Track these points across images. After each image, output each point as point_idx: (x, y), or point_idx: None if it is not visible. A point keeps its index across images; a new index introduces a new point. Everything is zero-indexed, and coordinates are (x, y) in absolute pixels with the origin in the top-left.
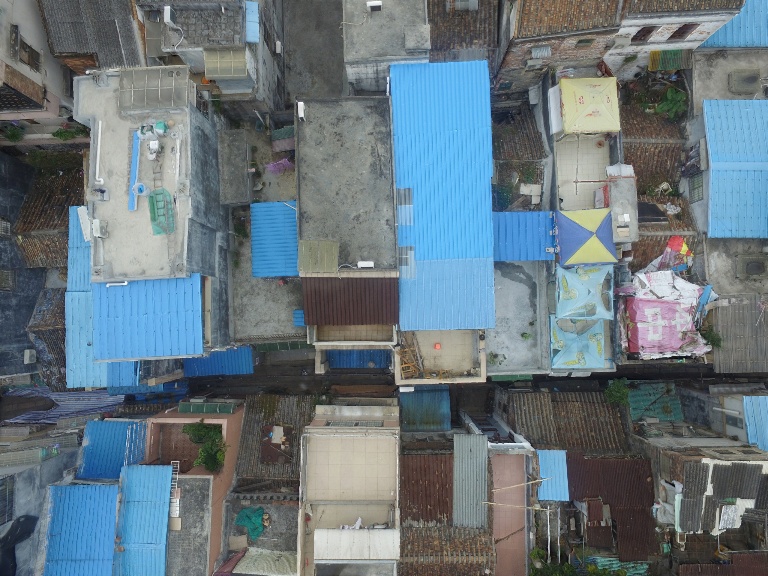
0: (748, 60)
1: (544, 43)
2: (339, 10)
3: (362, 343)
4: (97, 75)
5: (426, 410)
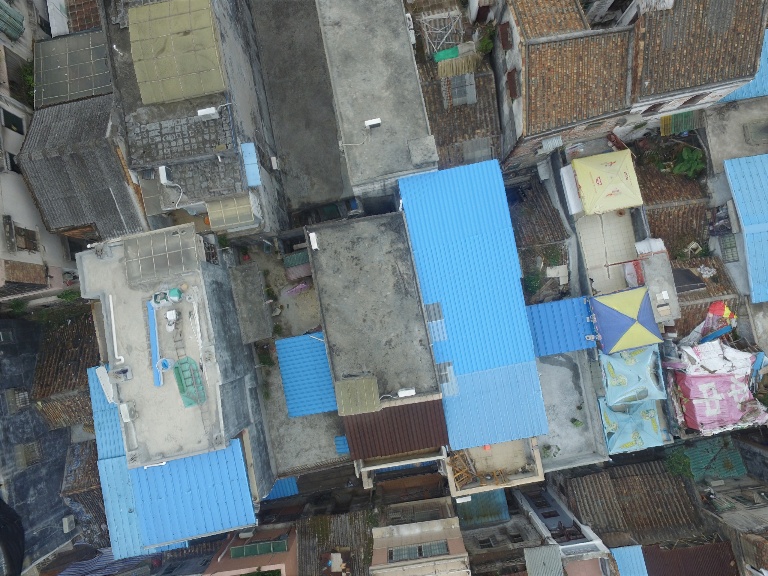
0: (760, 107)
1: (554, 134)
2: (327, 105)
3: (411, 462)
4: (100, 249)
5: (481, 502)
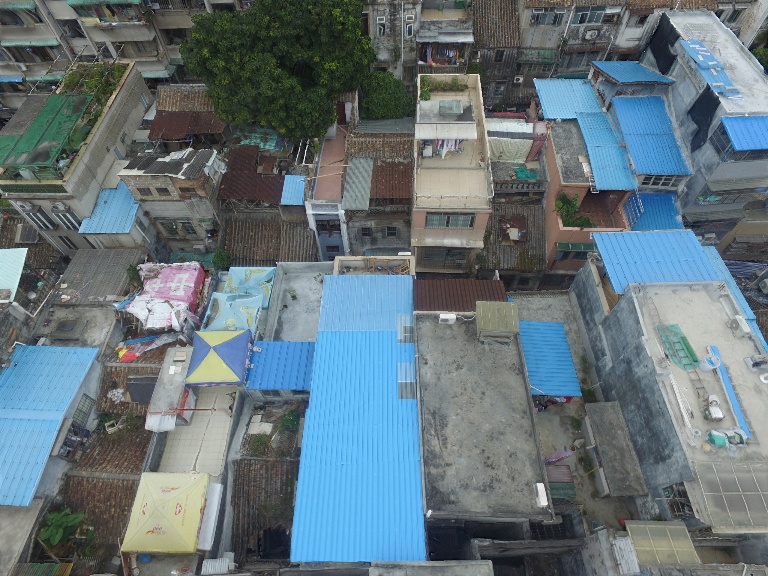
0: None
1: None
2: None
3: None
4: None
5: None
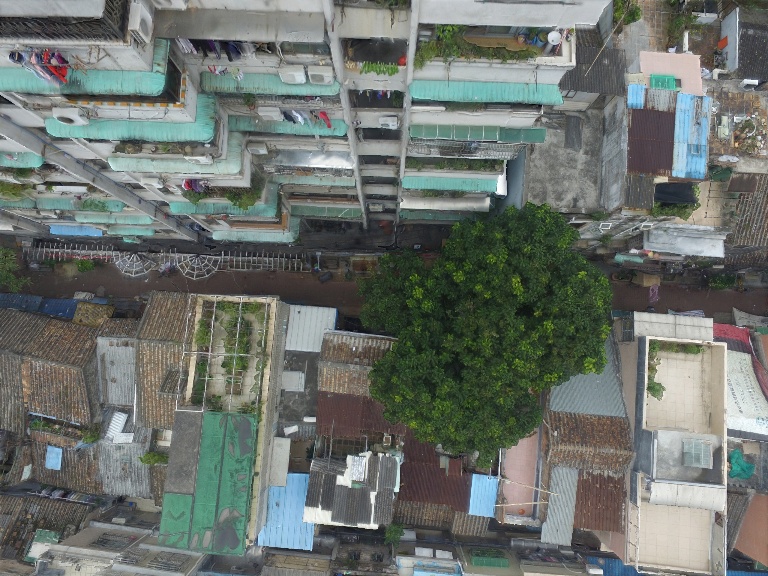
0: None
1: None
2: None
3: None
4: None
5: None
